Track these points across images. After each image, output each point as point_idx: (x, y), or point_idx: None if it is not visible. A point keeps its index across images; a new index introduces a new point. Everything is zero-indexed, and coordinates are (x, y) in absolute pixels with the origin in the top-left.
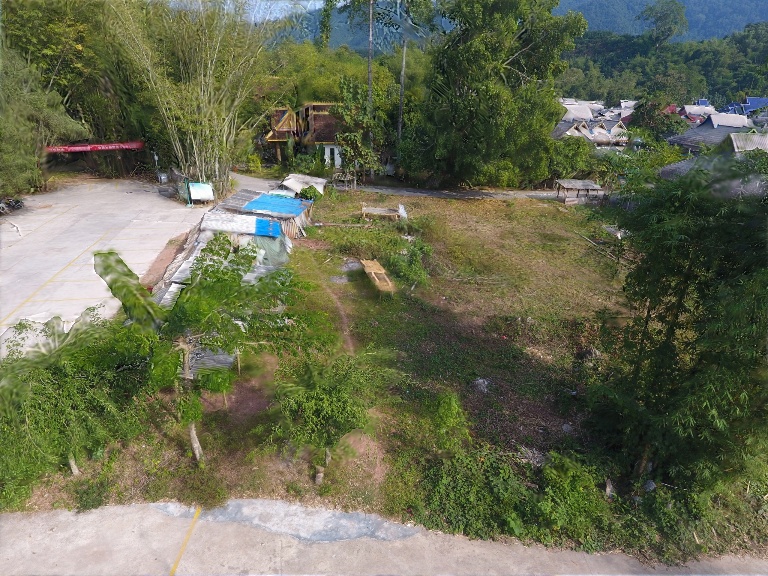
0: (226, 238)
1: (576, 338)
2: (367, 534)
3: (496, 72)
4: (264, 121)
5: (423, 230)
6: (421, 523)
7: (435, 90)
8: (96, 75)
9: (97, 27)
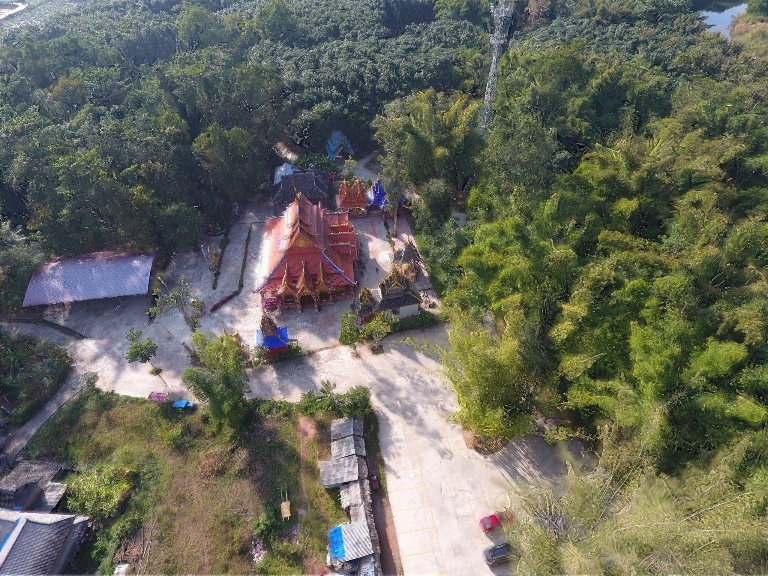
0: None
1: (228, 460)
2: None
3: None
4: None
5: None
6: None
7: None
8: None
9: None
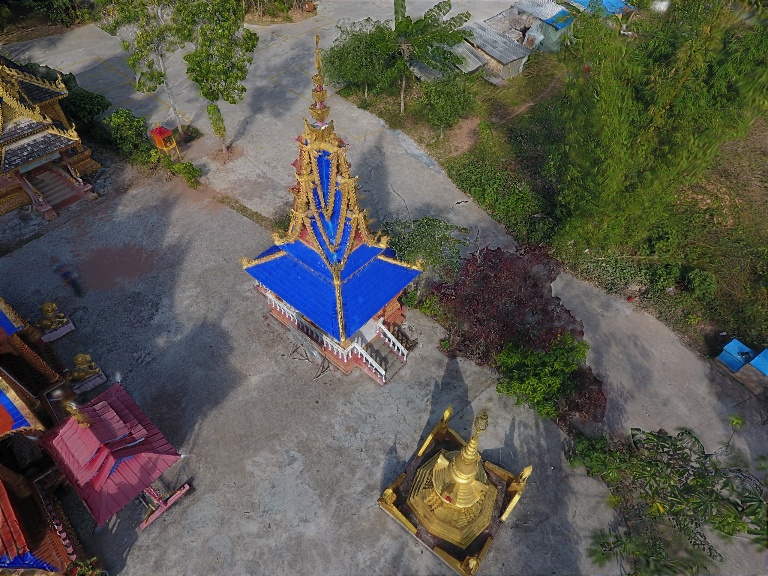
0: (449, 3)
1: None
2: (427, 164)
3: None
4: None
5: None
6: (448, 173)
7: None
8: None
9: None
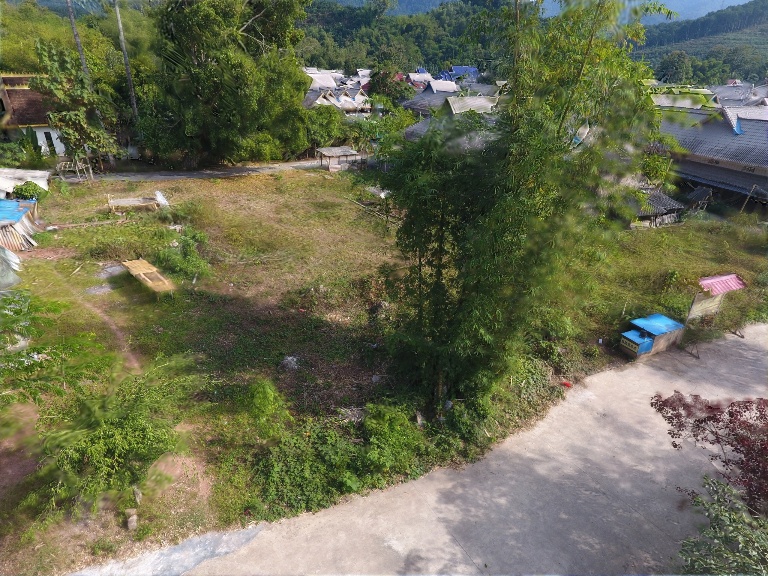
0: None
1: (366, 295)
2: (206, 556)
3: (233, 39)
4: None
5: (191, 216)
6: (262, 519)
7: (167, 58)
8: None
9: None
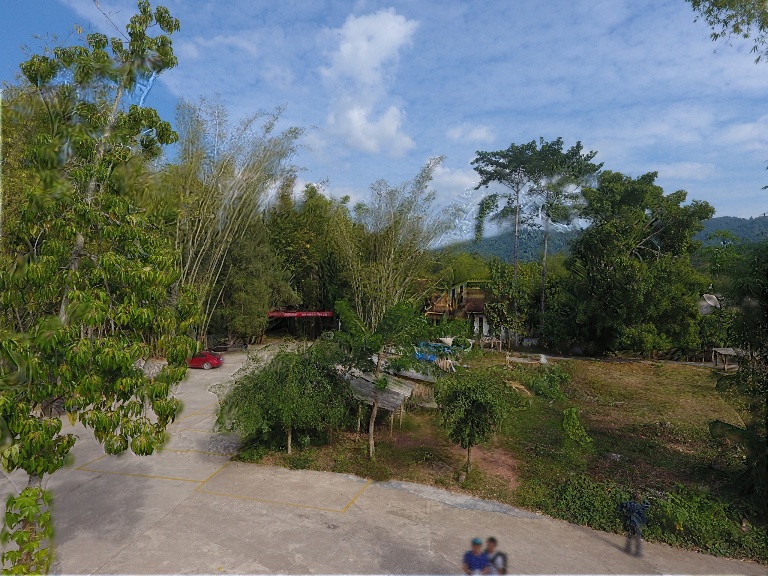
0: None
1: (721, 441)
2: (500, 511)
3: (628, 247)
4: (426, 296)
5: None
6: (548, 514)
7: (575, 271)
8: (314, 264)
9: (322, 234)
